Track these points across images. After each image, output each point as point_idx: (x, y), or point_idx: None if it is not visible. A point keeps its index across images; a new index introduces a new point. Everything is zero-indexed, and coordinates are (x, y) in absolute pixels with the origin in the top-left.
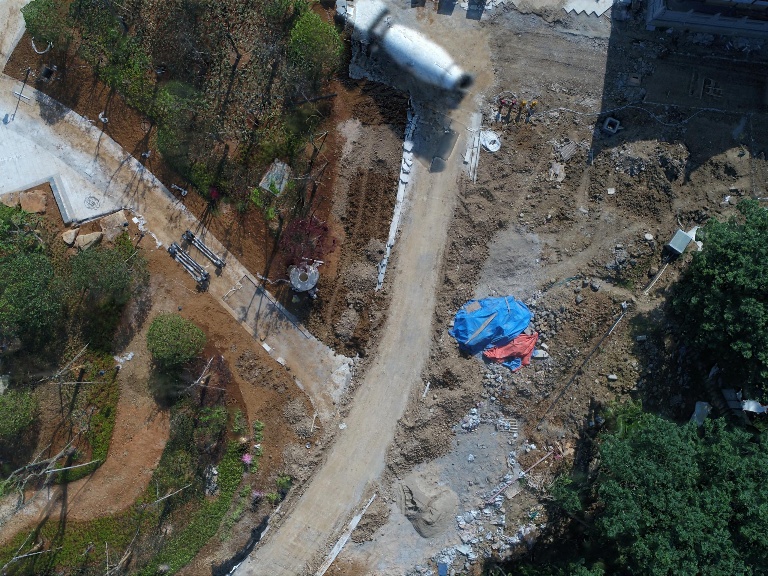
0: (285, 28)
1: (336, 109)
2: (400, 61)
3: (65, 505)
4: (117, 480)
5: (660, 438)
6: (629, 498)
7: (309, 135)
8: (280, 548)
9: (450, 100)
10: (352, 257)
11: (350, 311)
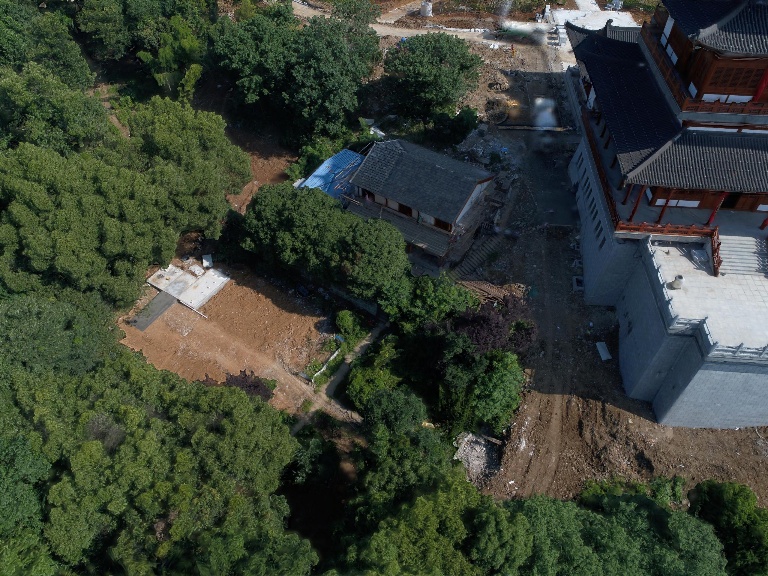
0: (526, 6)
1: (497, 16)
2: (523, 30)
3: None
4: None
5: (375, 8)
6: (349, 7)
7: (484, 11)
8: None
9: (510, 39)
10: (436, 22)
11: (413, 21)
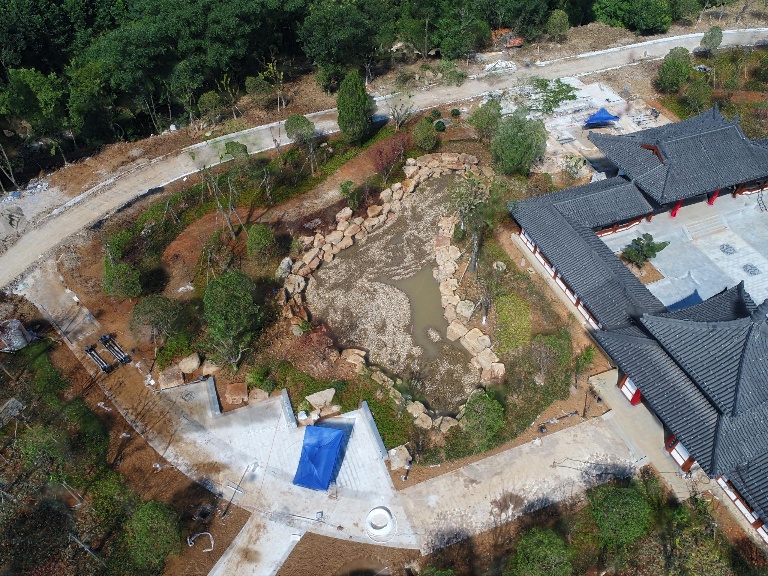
0: None
1: None
2: None
3: (250, 215)
4: (210, 226)
5: None
6: None
7: None
8: (116, 201)
9: None
10: None
11: None
